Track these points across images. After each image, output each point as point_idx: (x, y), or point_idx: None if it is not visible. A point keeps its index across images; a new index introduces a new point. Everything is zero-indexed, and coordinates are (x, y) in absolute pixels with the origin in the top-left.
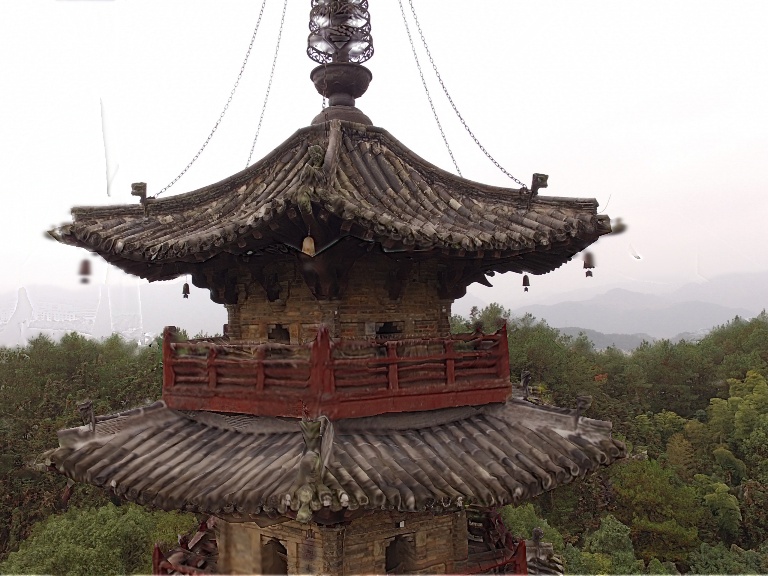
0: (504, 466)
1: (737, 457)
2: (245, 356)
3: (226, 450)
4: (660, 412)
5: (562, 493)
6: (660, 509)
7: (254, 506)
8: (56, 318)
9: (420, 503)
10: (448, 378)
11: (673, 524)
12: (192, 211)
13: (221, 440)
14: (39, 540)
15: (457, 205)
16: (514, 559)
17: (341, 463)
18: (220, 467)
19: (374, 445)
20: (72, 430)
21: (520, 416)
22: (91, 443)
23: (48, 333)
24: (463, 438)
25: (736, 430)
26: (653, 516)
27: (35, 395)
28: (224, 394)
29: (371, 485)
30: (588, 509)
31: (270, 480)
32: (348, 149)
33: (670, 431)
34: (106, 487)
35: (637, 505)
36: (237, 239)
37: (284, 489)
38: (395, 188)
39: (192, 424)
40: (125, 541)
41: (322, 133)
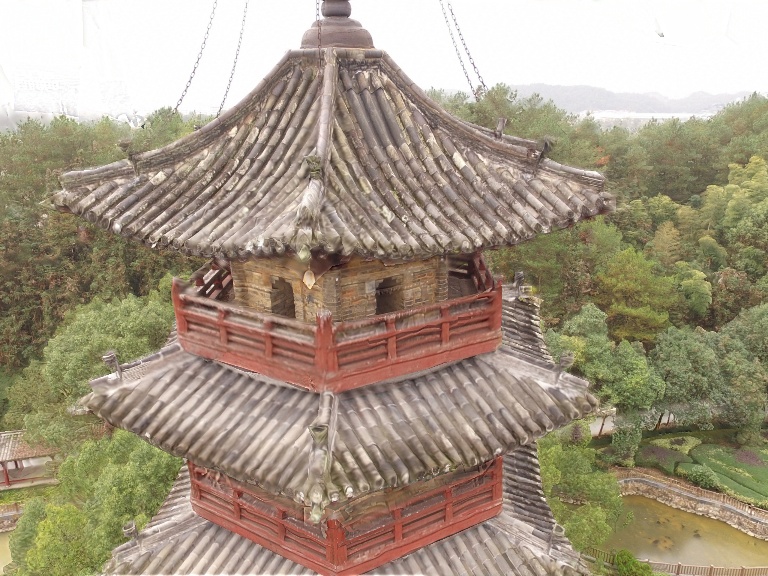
0: (488, 424)
1: (721, 243)
2: (252, 319)
3: (243, 402)
4: (656, 196)
5: (549, 280)
6: (638, 296)
7: (273, 487)
8: (39, 87)
9: (413, 476)
10: (443, 340)
11: (647, 310)
12: (183, 164)
13: (237, 388)
14: (72, 328)
15: (461, 163)
16: (492, 470)
17: (345, 441)
18: (239, 425)
19: (374, 408)
20: (101, 379)
21: (507, 364)
22: (121, 389)
23: (36, 116)
24: (454, 389)
25: (726, 218)
26: (630, 301)
27: (37, 183)
28: (236, 352)
29: (372, 470)
30: (572, 294)
31: (285, 459)
32: (345, 86)
33: (662, 216)
34: (142, 437)
35: (617, 292)
36: (237, 256)
37: (298, 481)
38: (396, 140)
39: (208, 364)
40: (150, 330)
41: (316, 61)
